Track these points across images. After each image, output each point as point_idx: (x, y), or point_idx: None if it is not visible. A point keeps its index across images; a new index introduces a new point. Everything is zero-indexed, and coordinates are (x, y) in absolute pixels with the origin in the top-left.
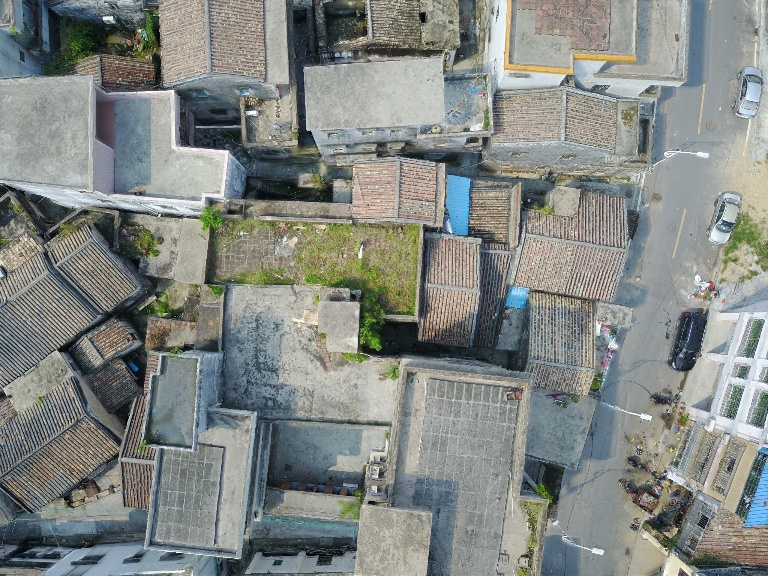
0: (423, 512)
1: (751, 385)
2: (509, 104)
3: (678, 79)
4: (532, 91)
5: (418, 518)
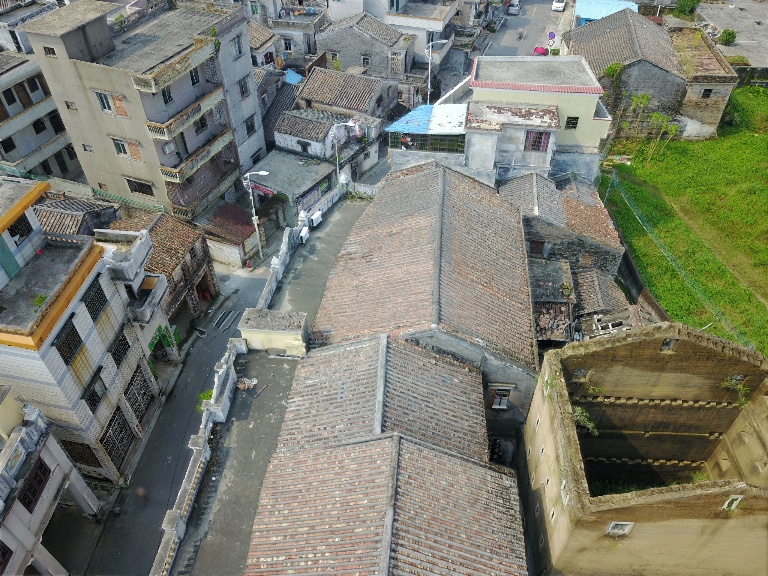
0: None
1: None
2: (333, 25)
3: (438, 19)
4: (347, 17)
5: None
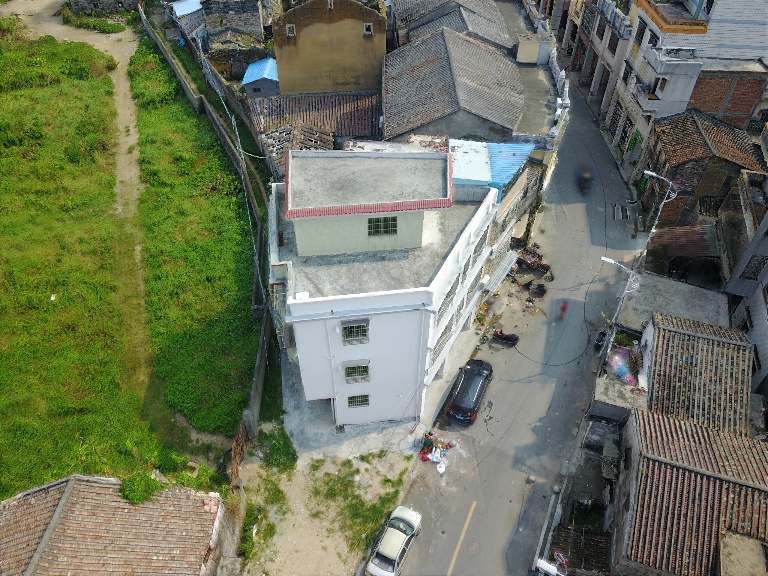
0: None
1: (466, 282)
2: None
3: None
4: None
5: None
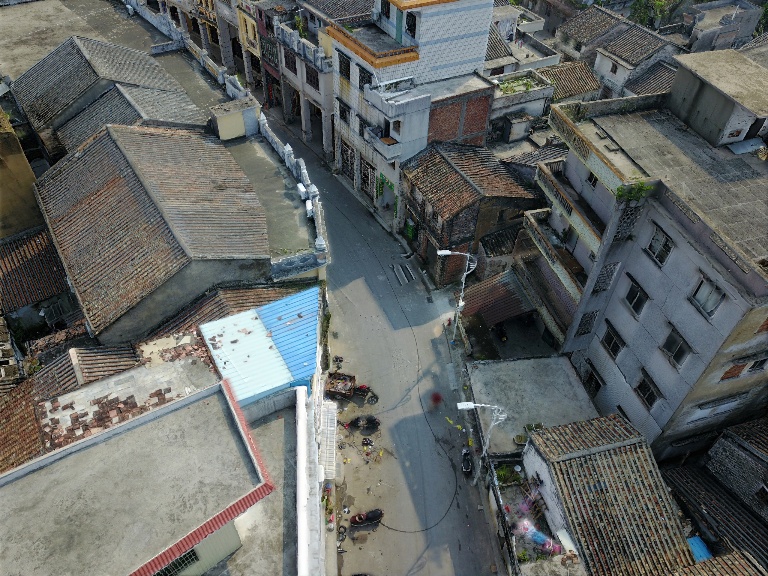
0: (767, 116)
1: None
2: None
3: None
4: None
5: (766, 111)
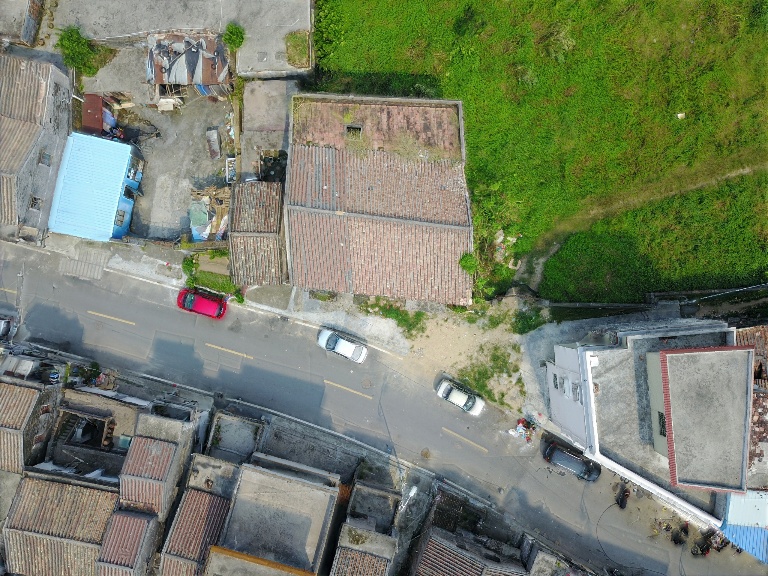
0: None
1: None
2: None
3: (334, 501)
4: None
5: None
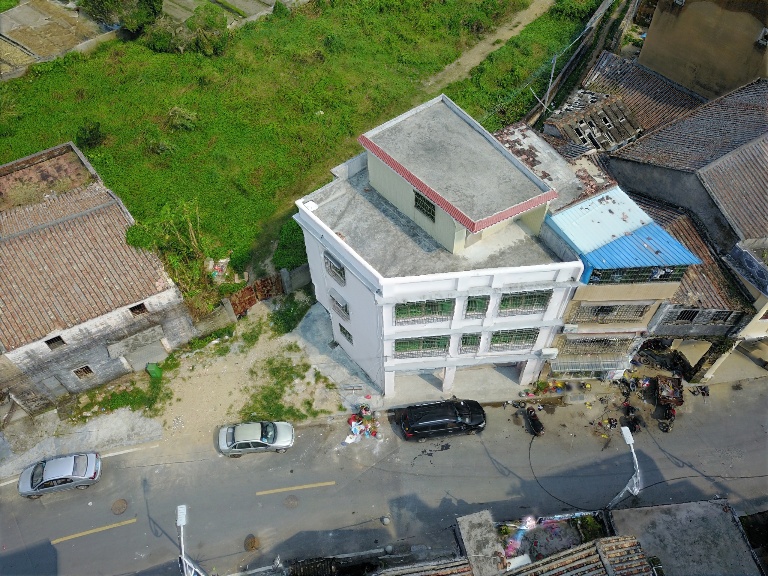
0: None
1: (490, 325)
2: None
3: None
4: None
5: None
